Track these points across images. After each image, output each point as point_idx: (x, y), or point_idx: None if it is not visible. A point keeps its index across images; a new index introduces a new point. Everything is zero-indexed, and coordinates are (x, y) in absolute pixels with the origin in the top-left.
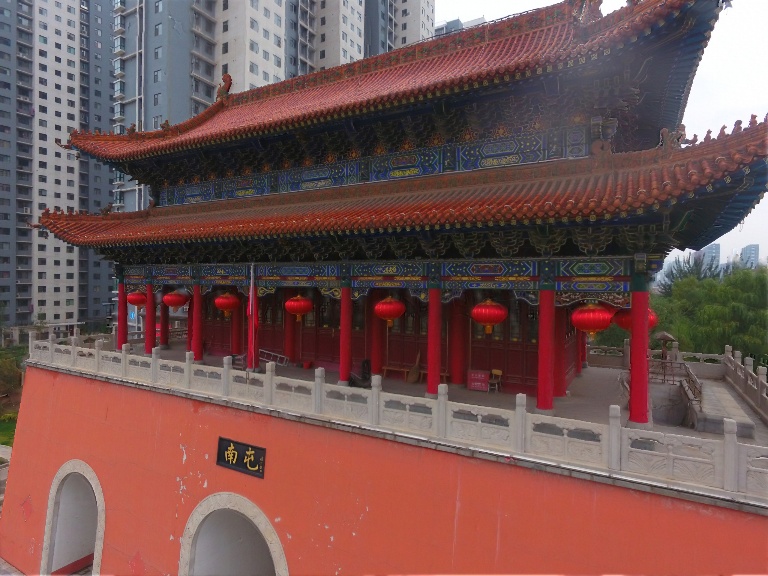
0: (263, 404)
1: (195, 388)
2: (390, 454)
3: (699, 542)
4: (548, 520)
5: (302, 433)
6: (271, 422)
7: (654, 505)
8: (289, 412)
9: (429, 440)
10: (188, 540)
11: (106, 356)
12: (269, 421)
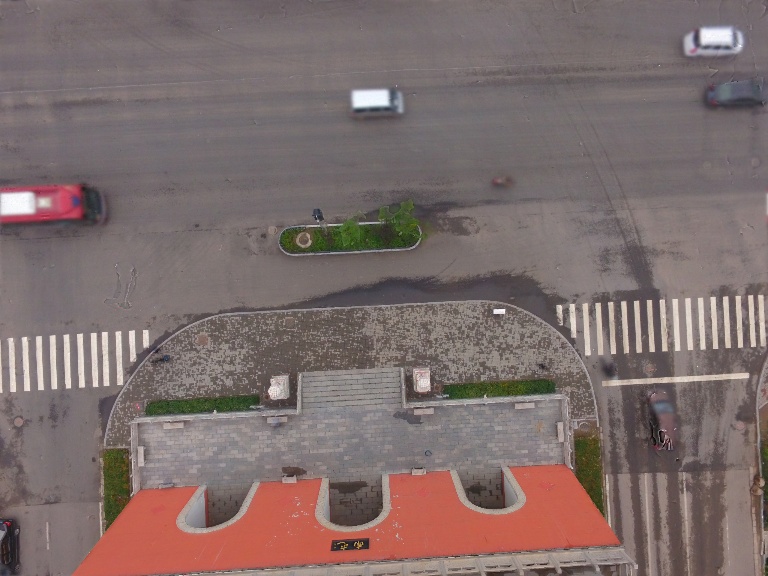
0: (333, 568)
1: (397, 566)
2: (248, 565)
3: (124, 568)
4: (178, 561)
5: (304, 562)
6: (327, 562)
7: (133, 574)
8: (311, 567)
9: (223, 572)
10: (386, 509)
11: (507, 567)
12: (328, 562)
